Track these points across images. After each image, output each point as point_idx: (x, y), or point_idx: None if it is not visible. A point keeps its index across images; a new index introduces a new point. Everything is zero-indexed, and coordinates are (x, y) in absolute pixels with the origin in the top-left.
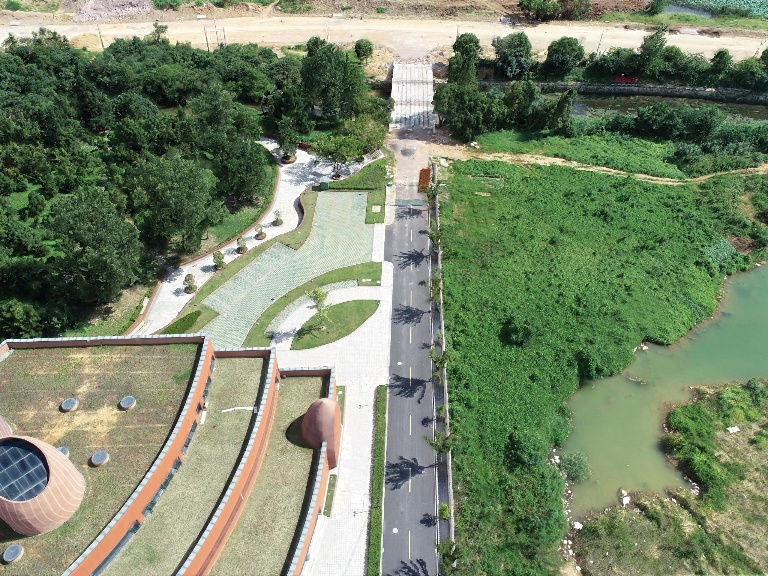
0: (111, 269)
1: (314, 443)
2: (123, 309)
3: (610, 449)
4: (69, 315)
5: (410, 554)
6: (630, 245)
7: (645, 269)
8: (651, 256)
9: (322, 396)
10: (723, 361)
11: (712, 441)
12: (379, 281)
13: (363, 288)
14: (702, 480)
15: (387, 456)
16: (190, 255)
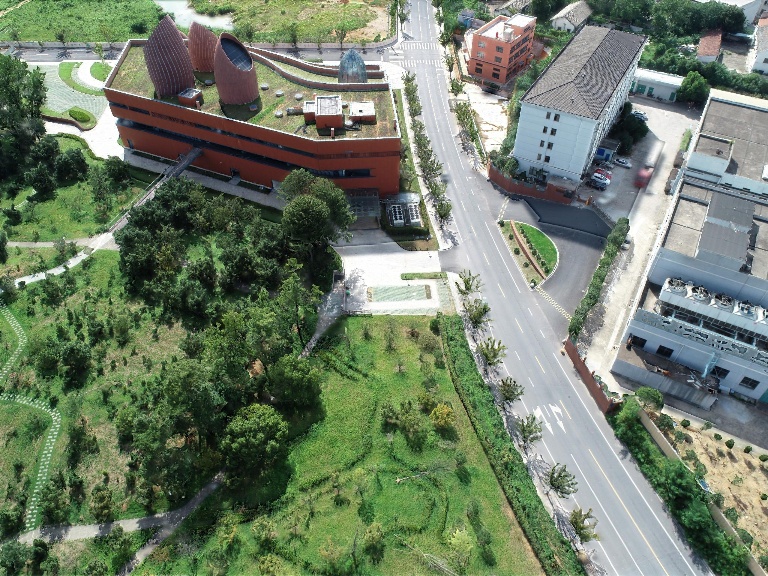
0: (43, 88)
1: None
2: None
3: (209, 24)
4: None
5: None
6: (96, 3)
7: (115, 2)
8: (107, 0)
9: None
10: (176, 2)
11: (213, 5)
12: (79, 62)
13: (81, 66)
14: (228, 10)
15: None
16: None
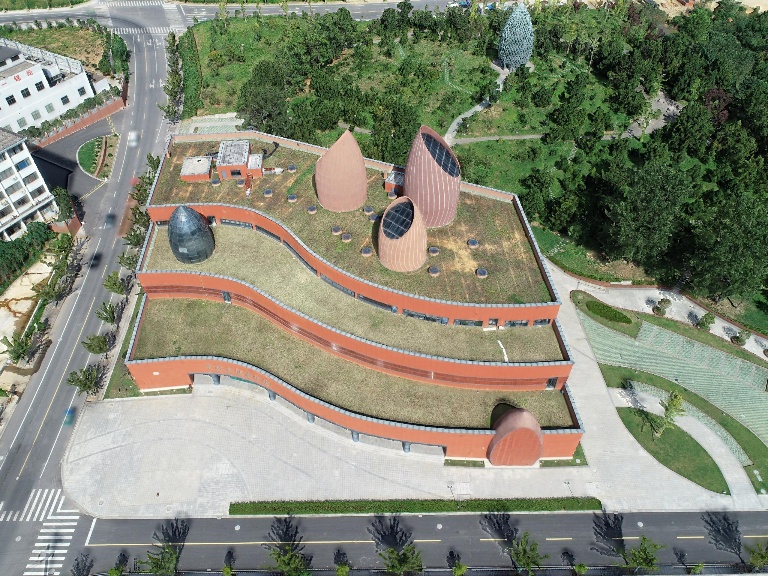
0: (619, 231)
1: (494, 425)
2: (611, 270)
3: None
4: (583, 236)
5: (419, 541)
6: None
7: None
8: None
9: (550, 428)
10: None
11: None
12: (765, 491)
13: (742, 472)
14: None
15: (516, 515)
16: (704, 300)
